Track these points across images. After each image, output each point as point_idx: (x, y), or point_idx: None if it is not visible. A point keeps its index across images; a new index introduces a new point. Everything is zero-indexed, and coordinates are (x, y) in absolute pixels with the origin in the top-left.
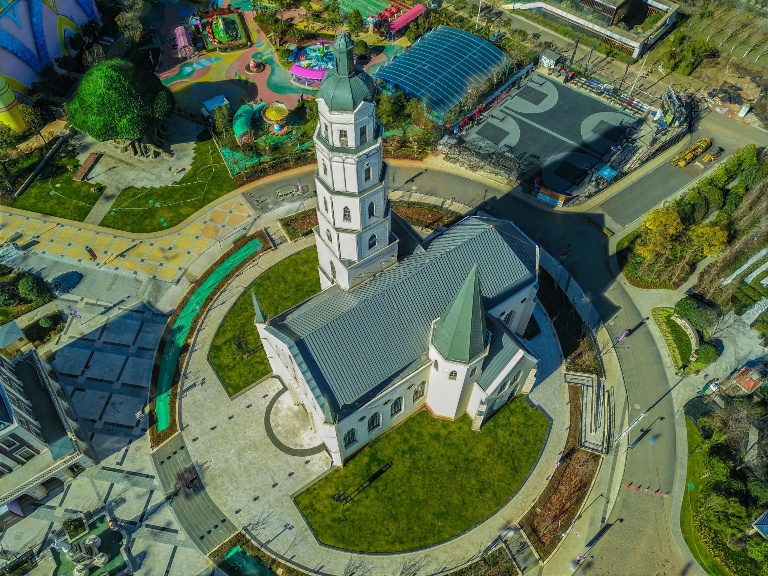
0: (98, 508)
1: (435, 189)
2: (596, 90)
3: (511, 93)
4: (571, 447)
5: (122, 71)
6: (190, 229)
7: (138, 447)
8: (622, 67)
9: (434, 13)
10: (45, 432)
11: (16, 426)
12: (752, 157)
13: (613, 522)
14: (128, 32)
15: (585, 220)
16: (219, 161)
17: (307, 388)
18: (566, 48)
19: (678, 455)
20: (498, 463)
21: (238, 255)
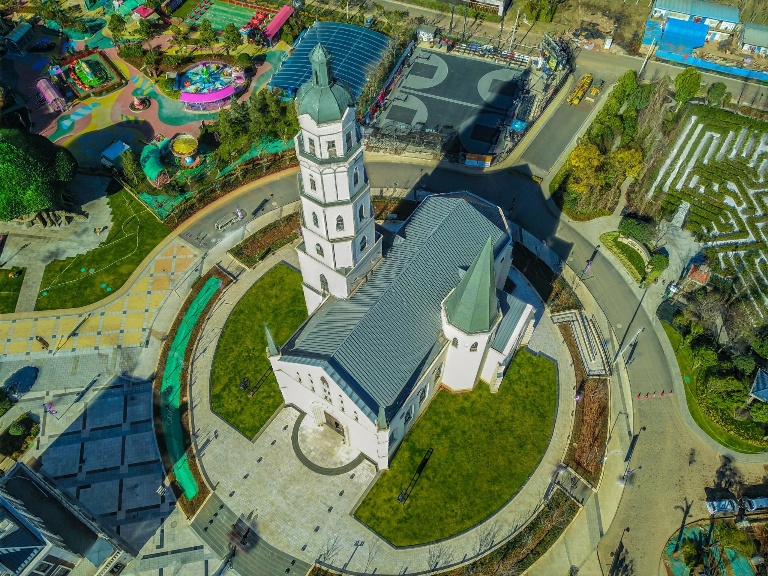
0: None
1: None
2: (478, 53)
3: (404, 73)
4: (581, 379)
5: (10, 140)
6: (138, 286)
7: (173, 523)
8: (492, 26)
9: (302, 12)
10: (70, 543)
11: (51, 546)
12: (633, 82)
13: (638, 432)
14: None
15: (514, 174)
16: (141, 209)
17: (348, 403)
18: (436, 20)
19: (667, 356)
20: (526, 415)
21: (200, 298)
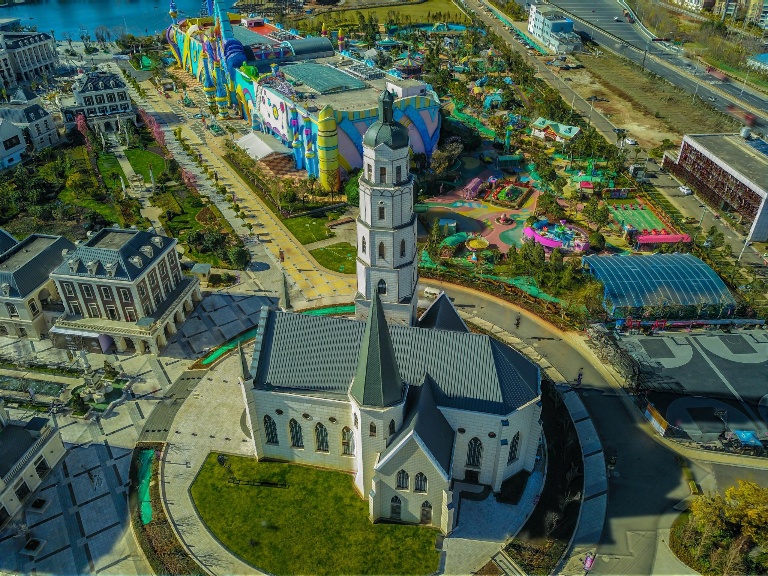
0: (131, 376)
1: (552, 355)
2: None
3: (714, 332)
4: None
5: None
6: (351, 280)
7: (184, 364)
8: None
9: (698, 247)
10: (153, 315)
11: (132, 283)
12: None
13: None
14: (435, 164)
15: (679, 463)
16: None
17: None
18: None
19: None
20: (357, 557)
21: None
